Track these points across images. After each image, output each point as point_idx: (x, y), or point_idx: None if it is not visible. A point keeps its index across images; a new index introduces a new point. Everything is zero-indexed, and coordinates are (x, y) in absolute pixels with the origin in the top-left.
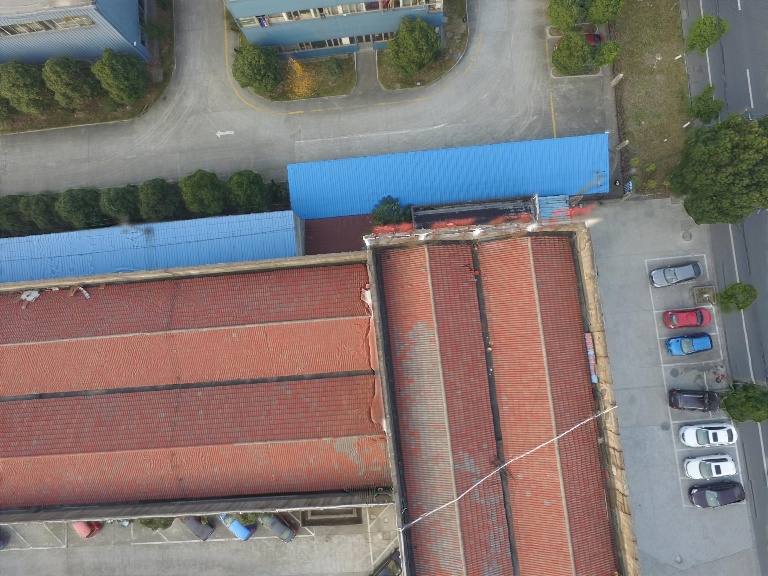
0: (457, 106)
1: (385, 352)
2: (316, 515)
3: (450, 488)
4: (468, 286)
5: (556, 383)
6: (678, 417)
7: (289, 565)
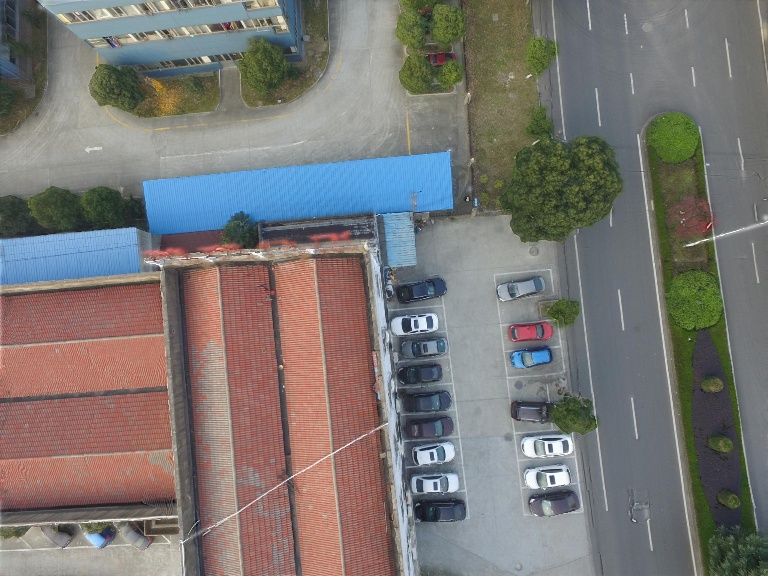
0: (316, 123)
1: (185, 369)
2: (160, 524)
3: (232, 502)
4: (262, 306)
5: (336, 400)
6: (521, 428)
7: (146, 572)
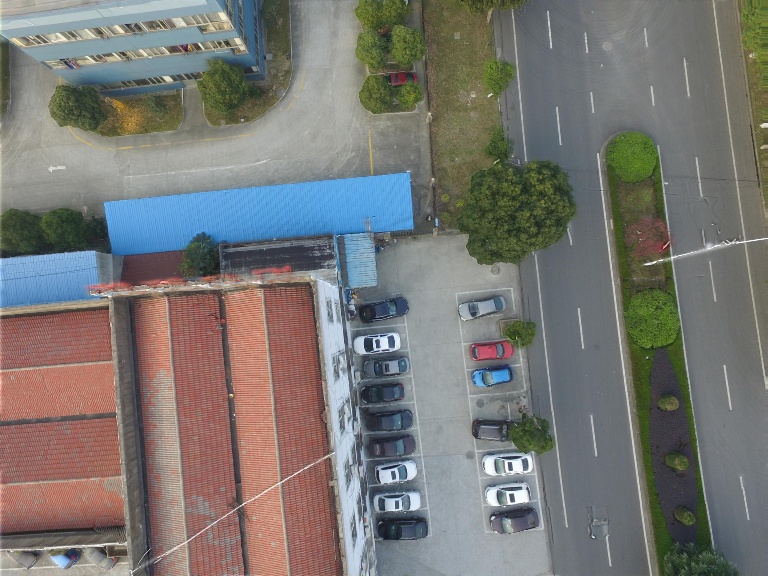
0: (279, 142)
1: (137, 398)
2: None
3: (182, 531)
4: (212, 334)
5: (284, 430)
6: (482, 446)
7: None
